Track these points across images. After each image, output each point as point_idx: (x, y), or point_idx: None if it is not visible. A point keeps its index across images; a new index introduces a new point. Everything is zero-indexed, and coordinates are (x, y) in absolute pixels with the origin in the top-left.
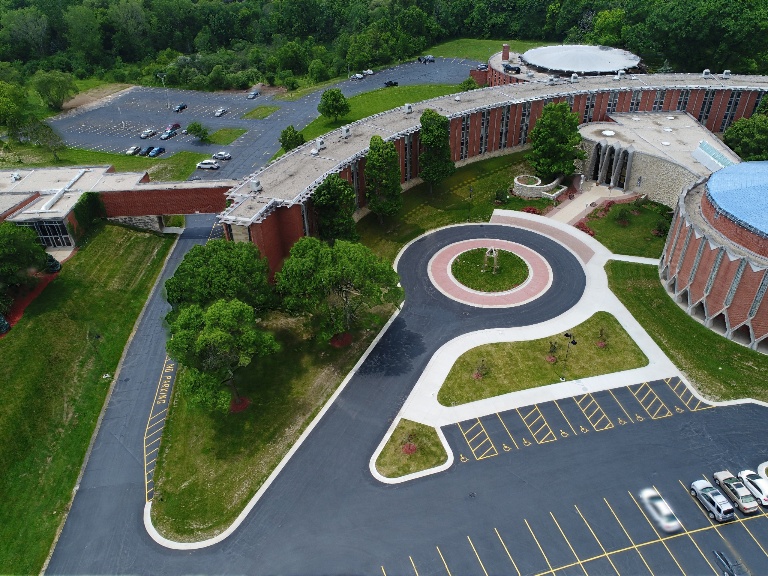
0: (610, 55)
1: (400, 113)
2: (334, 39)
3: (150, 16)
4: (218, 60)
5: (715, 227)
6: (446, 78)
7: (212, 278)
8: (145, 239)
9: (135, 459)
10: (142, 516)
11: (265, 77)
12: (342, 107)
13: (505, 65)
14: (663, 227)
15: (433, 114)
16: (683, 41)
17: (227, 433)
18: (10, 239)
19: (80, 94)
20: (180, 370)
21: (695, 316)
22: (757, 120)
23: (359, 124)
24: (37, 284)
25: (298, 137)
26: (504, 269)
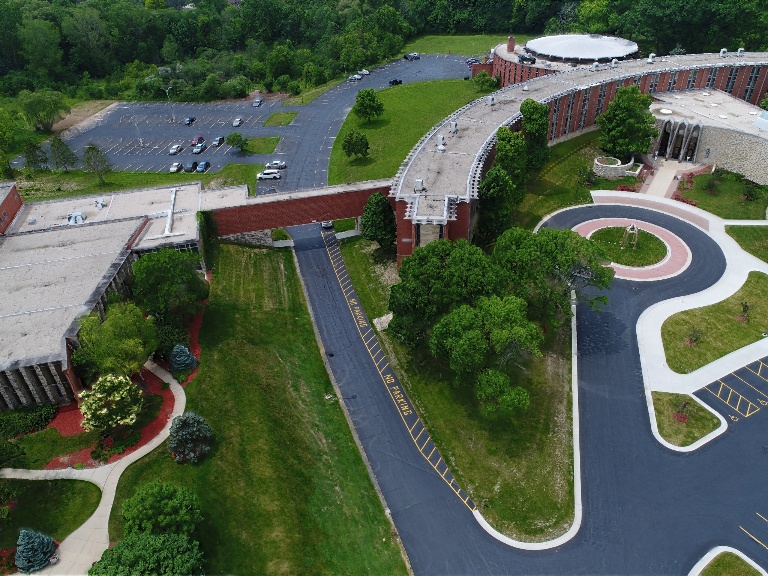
0: (604, 42)
1: (484, 106)
2: (316, 41)
3: (109, 27)
4: (201, 69)
5: None
6: (443, 74)
7: (467, 277)
8: (265, 255)
9: (427, 472)
10: (479, 525)
11: (263, 83)
12: (378, 107)
13: (521, 56)
14: (752, 191)
15: (536, 103)
16: (678, 25)
17: (500, 431)
18: (182, 266)
19: None
20: (402, 379)
21: None
22: None
23: (455, 119)
24: (193, 313)
25: (363, 138)
26: (641, 244)
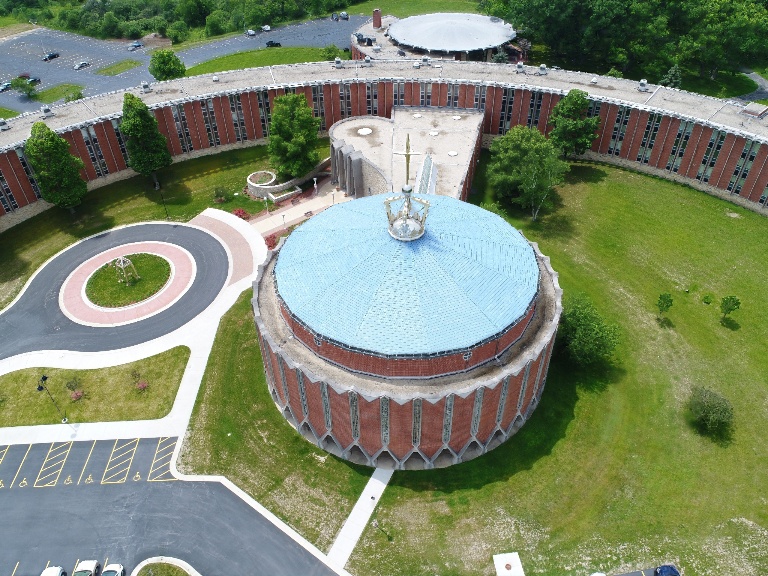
0: (492, 29)
1: (137, 92)
2: None
3: None
4: (127, 5)
5: None
6: (340, 41)
7: None
8: None
9: None
10: None
11: None
12: (172, 71)
13: (357, 35)
14: None
15: (129, 100)
16: (550, 20)
17: None
18: None
19: None
20: None
21: None
22: (514, 133)
23: (79, 102)
24: None
25: None
26: (141, 281)
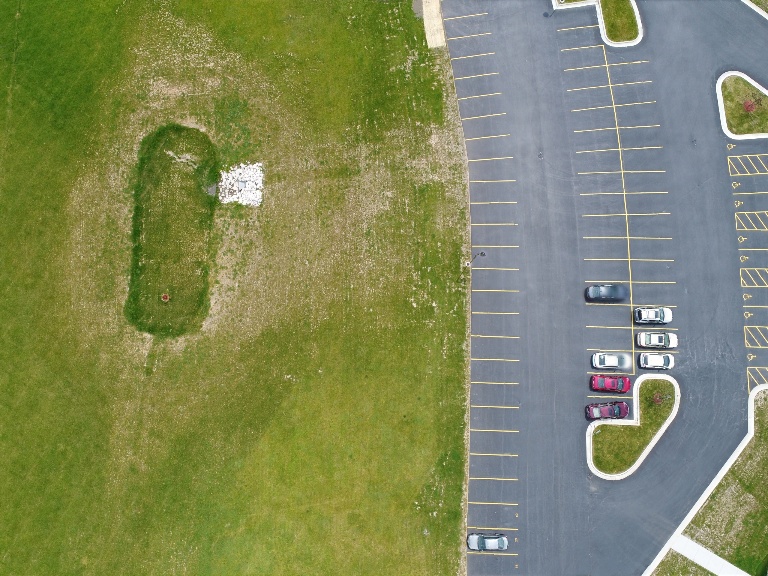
0: None
1: None
2: None
3: None
4: None
5: None
6: None
7: None
8: None
9: None
10: None
11: None
12: None
13: None
14: None
15: None
16: None
17: None
18: None
19: None
20: None
21: None
22: None
23: None
24: None
25: None
26: None
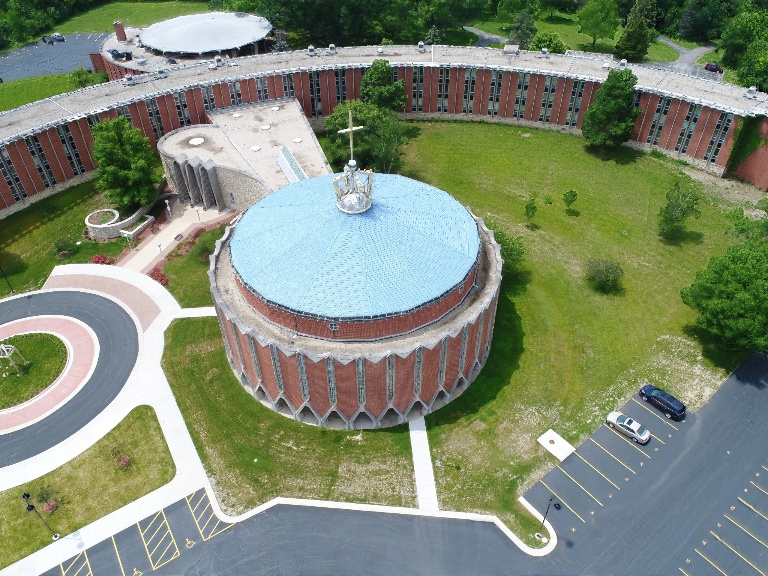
0: (244, 24)
1: None
2: None
3: None
4: None
5: (237, 286)
6: (71, 64)
7: None
8: None
9: None
10: None
11: None
12: None
13: (111, 51)
14: None
15: None
16: (305, 6)
17: None
18: None
19: None
20: None
21: (248, 385)
22: (347, 108)
23: None
24: None
25: None
26: (34, 365)
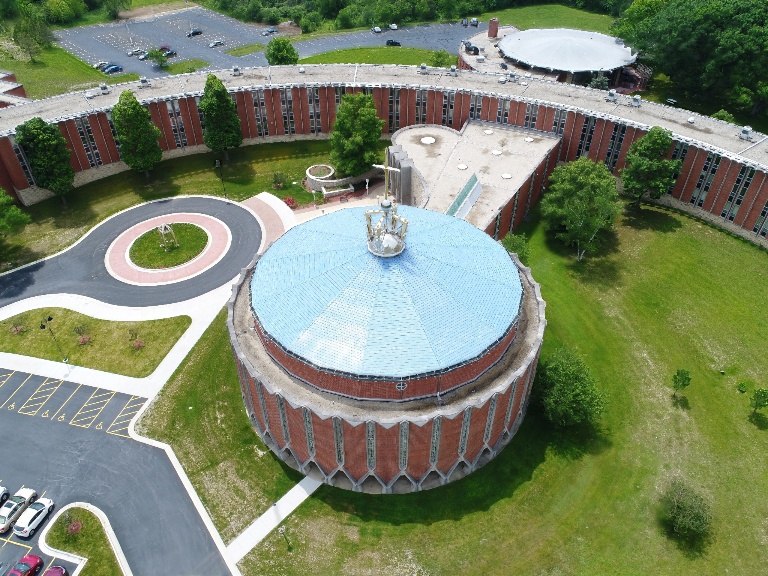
0: (612, 51)
1: (229, 74)
2: None
3: None
4: None
5: None
6: None
7: None
8: None
9: None
10: None
11: (292, 16)
12: (284, 58)
13: (465, 42)
14: None
15: (210, 80)
16: (671, 48)
17: None
18: None
19: (149, 7)
20: None
21: None
22: (574, 165)
23: (176, 77)
24: None
25: None
26: (178, 249)
